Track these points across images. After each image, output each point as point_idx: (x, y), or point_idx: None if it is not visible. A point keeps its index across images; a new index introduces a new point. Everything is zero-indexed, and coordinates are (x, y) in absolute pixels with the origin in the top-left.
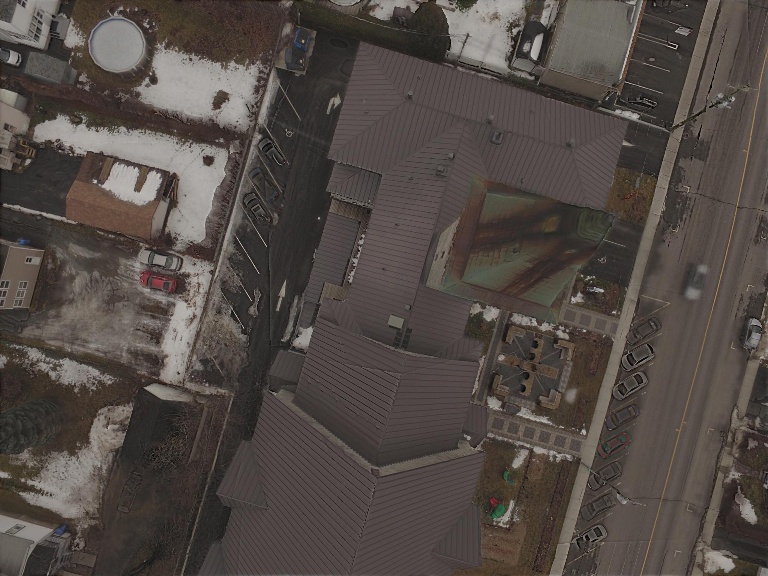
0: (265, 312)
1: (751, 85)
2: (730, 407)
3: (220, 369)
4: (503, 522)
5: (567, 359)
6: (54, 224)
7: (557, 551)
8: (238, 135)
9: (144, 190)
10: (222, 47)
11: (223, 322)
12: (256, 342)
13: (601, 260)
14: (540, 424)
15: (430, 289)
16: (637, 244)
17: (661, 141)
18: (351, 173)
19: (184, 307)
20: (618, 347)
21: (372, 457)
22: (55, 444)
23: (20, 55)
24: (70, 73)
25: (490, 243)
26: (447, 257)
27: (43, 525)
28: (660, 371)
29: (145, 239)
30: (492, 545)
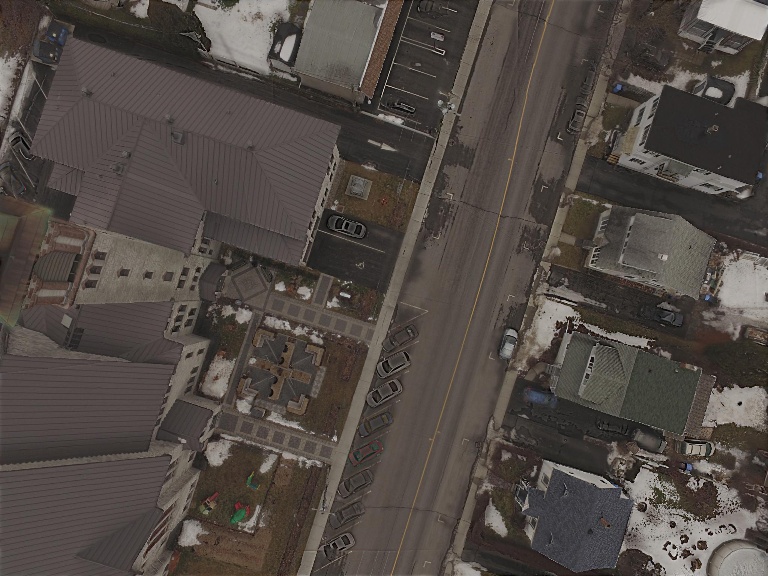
0: None
1: (518, 93)
2: (486, 418)
3: None
4: (248, 527)
5: (315, 364)
6: None
7: (303, 558)
8: None
9: None
10: None
11: None
12: None
13: (359, 265)
14: (290, 429)
15: None
16: (397, 250)
17: (425, 147)
18: (69, 169)
19: None
20: (373, 354)
21: None
22: None
23: None
24: None
25: None
26: None
27: None
28: (415, 379)
29: None
30: (236, 550)
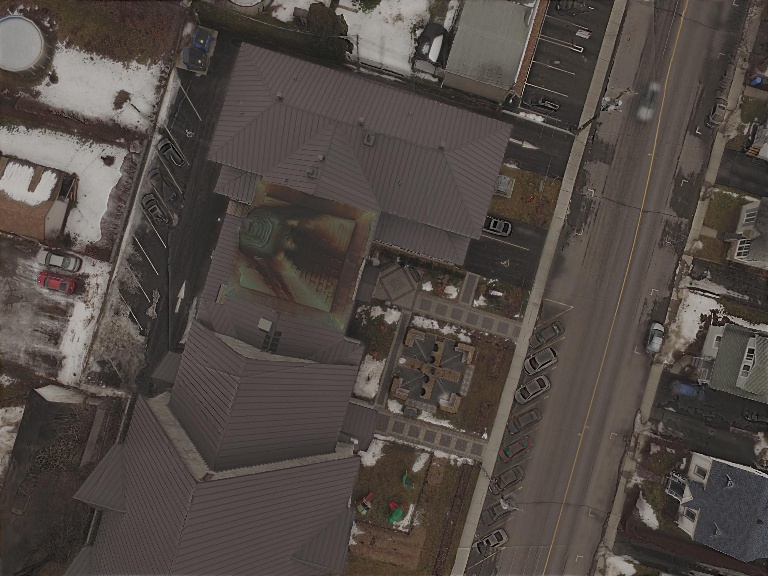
0: (164, 313)
1: (656, 89)
2: (633, 412)
3: (117, 371)
4: (403, 526)
5: (467, 362)
6: None
7: (457, 555)
8: (138, 135)
9: (38, 190)
10: (124, 47)
11: (121, 323)
12: (154, 344)
13: (504, 263)
14: (441, 428)
15: None
16: (541, 247)
17: (566, 144)
18: (238, 174)
19: (82, 308)
20: (521, 351)
21: (211, 462)
22: None
23: None
24: None
25: None
26: None
27: None
28: (563, 375)
29: (39, 239)
30: (391, 549)
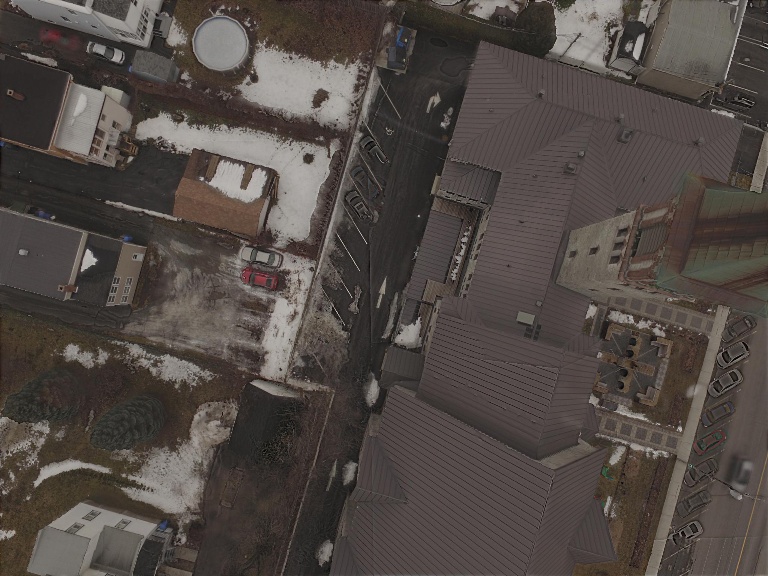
0: (365, 309)
1: None
2: None
3: (321, 365)
4: None
5: (665, 356)
6: (156, 221)
7: (654, 547)
8: (338, 133)
9: (250, 187)
10: (322, 46)
11: (324, 319)
12: (357, 339)
13: None
14: (637, 421)
15: (558, 286)
16: None
17: (756, 140)
18: (465, 171)
19: (285, 304)
20: (713, 345)
21: (530, 451)
22: (156, 440)
23: (124, 53)
24: (175, 71)
25: (729, 237)
26: (613, 253)
27: (147, 520)
28: (755, 369)
29: (251, 236)
30: None
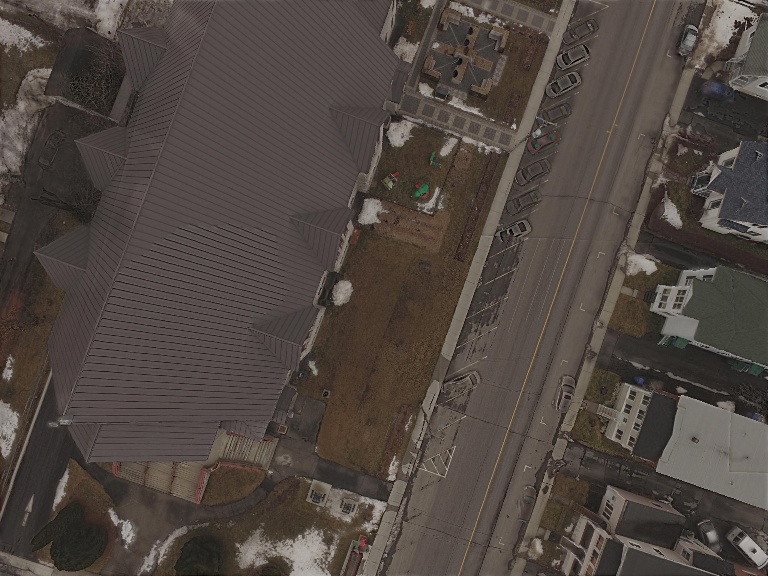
0: None
1: None
2: (662, 114)
3: None
4: (427, 209)
5: (501, 46)
6: None
7: (480, 242)
8: None
9: None
10: None
11: None
12: None
13: None
14: (471, 115)
15: None
16: None
17: None
18: None
19: None
20: (554, 45)
21: None
22: None
23: None
24: None
25: None
26: None
27: None
28: (594, 72)
29: None
30: (415, 230)
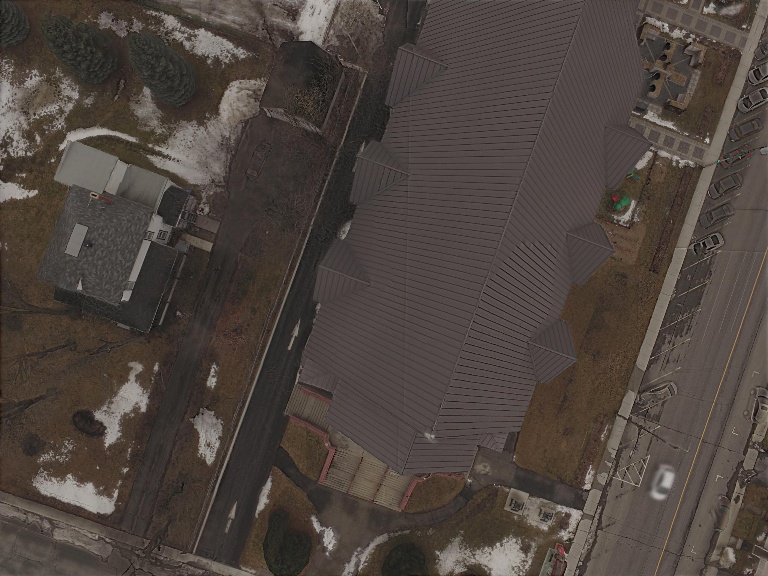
0: None
1: None
2: None
3: (355, 46)
4: (623, 221)
5: (698, 61)
6: None
7: (674, 255)
8: None
9: None
10: None
11: (362, 0)
12: (393, 23)
13: None
14: (665, 129)
15: None
16: None
17: None
18: None
19: None
20: (746, 61)
21: None
22: (184, 113)
23: None
24: None
25: None
26: None
27: None
28: None
29: None
30: (612, 242)
